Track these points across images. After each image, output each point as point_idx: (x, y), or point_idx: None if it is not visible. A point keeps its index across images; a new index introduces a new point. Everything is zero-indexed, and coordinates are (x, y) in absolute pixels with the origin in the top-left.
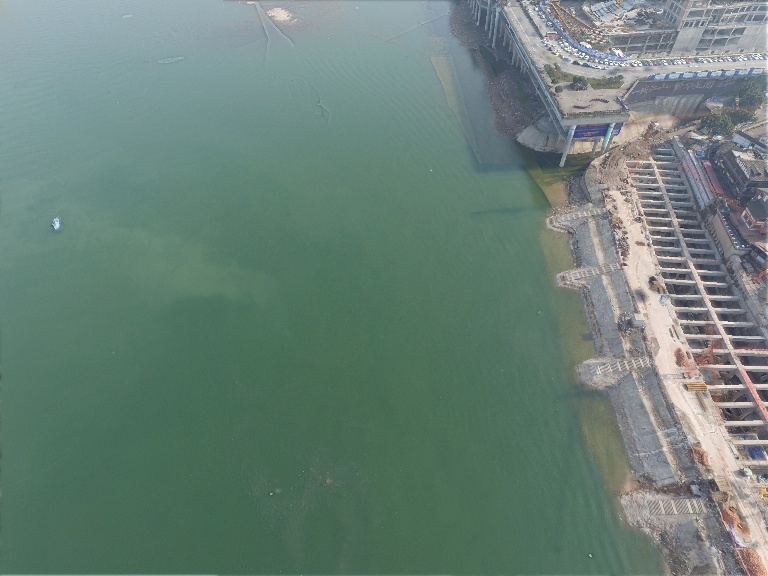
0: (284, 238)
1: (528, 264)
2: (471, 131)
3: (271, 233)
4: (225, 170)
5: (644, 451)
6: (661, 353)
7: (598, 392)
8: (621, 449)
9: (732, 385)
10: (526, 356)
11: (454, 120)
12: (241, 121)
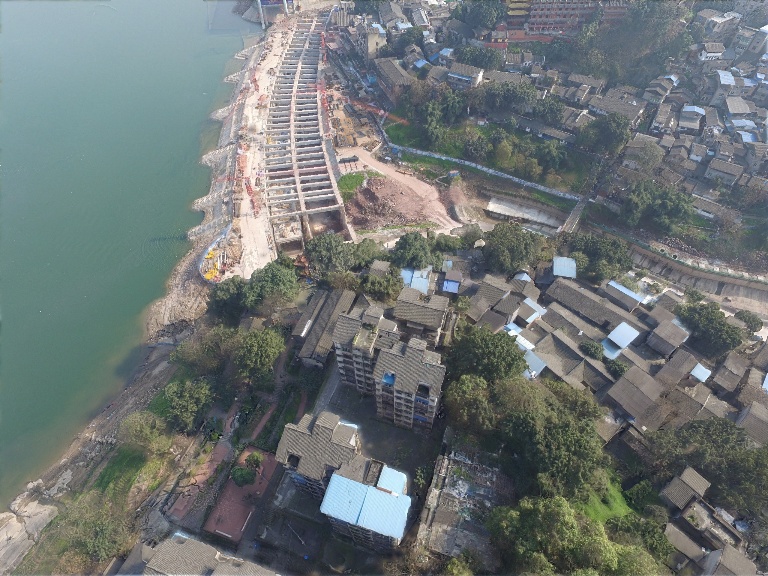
0: (50, 68)
1: (211, 74)
2: (213, 13)
3: (42, 66)
4: (23, 41)
5: (224, 137)
6: (252, 96)
7: (218, 122)
8: (216, 140)
9: (283, 106)
10: (184, 110)
11: (205, 8)
12: (44, 13)
